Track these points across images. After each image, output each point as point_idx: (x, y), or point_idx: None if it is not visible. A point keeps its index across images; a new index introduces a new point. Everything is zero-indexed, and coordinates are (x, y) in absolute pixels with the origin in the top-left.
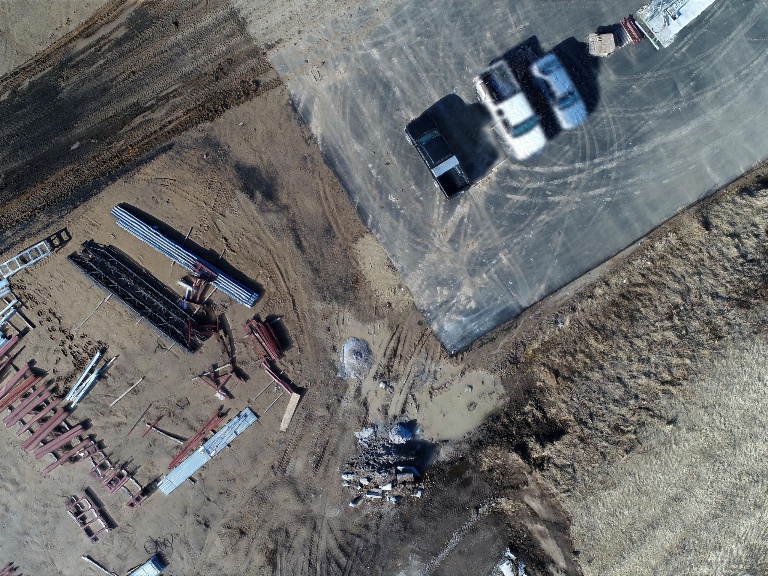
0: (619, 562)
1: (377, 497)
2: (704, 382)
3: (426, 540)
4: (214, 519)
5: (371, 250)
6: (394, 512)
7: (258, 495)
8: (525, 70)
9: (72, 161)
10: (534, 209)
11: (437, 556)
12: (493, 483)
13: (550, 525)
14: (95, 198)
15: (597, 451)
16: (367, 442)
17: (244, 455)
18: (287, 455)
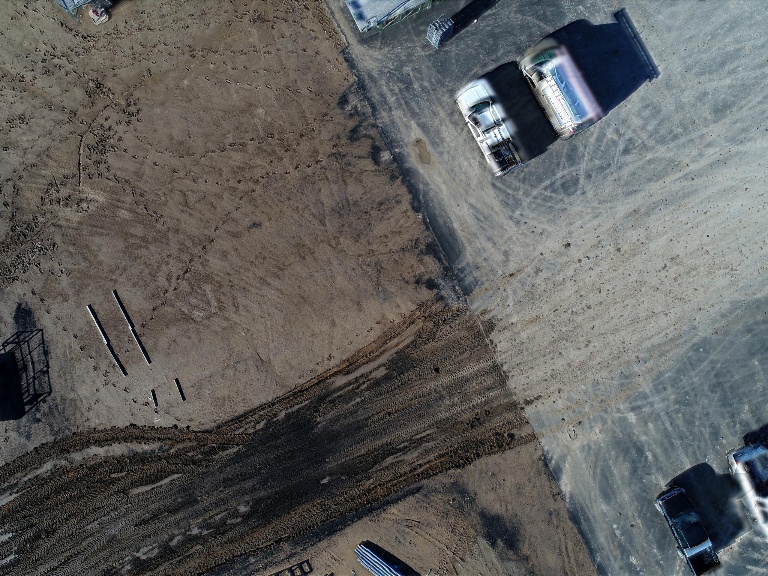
0: None
1: None
2: None
3: None
4: None
5: None
6: None
7: None
8: None
9: (320, 495)
10: None
11: None
12: None
13: None
14: (339, 533)
15: None
16: None
17: None
18: None
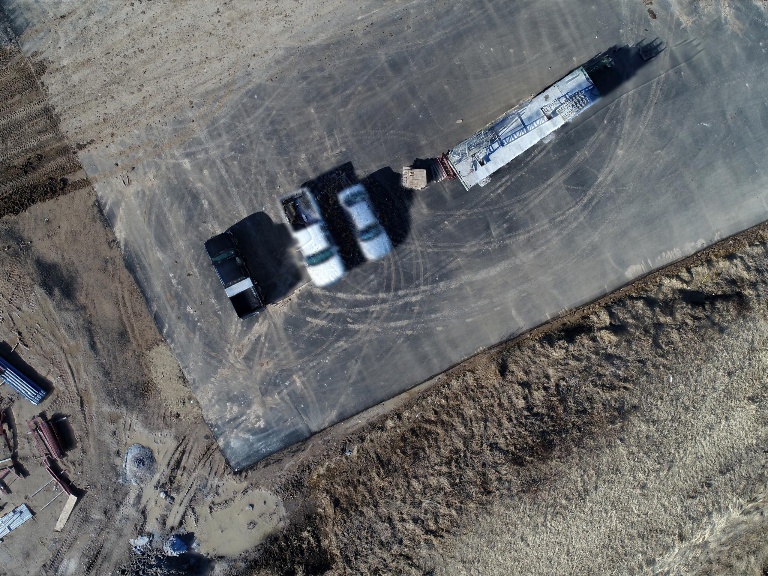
0: None
1: None
2: (466, 536)
3: None
4: None
5: (164, 359)
6: None
7: None
8: (337, 195)
9: None
10: (333, 335)
11: None
12: None
13: None
14: None
15: None
16: (141, 550)
17: (16, 551)
18: (60, 555)
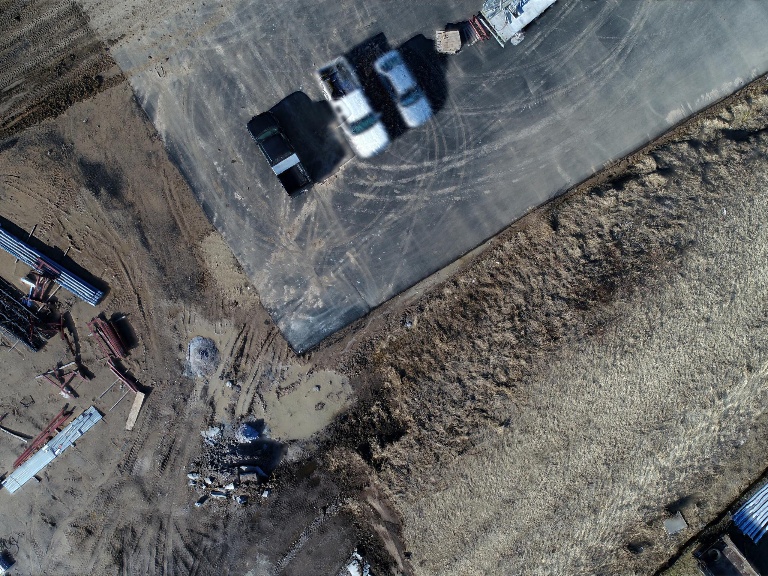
0: (450, 563)
1: (222, 496)
2: (538, 383)
3: (274, 540)
4: (60, 517)
5: (217, 248)
6: (241, 511)
7: (104, 494)
8: (373, 67)
9: None
10: (382, 208)
11: (285, 556)
12: (340, 483)
13: (389, 525)
14: None
15: (431, 452)
16: (213, 441)
17: (89, 454)
18: (133, 454)
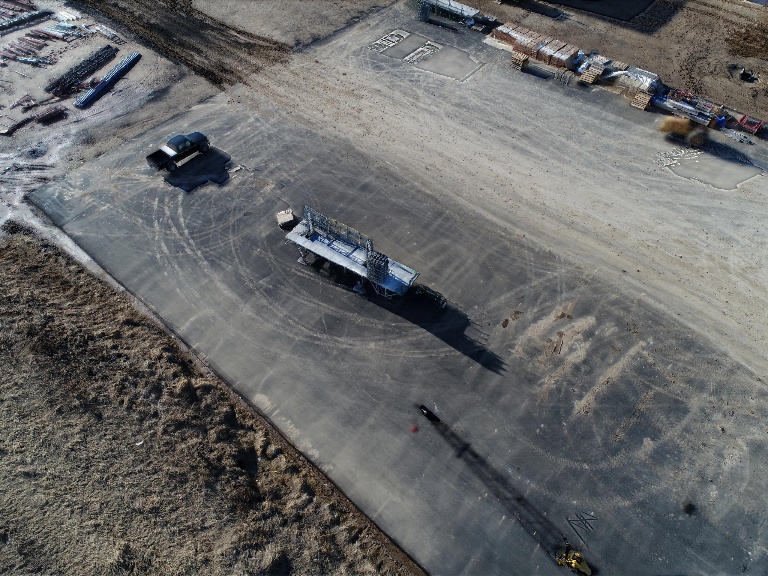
0: None
1: None
2: None
3: None
4: None
5: (112, 144)
6: None
7: None
8: (257, 187)
9: (166, 39)
10: (147, 215)
11: None
12: None
13: None
14: (144, 48)
15: None
16: None
17: None
18: None
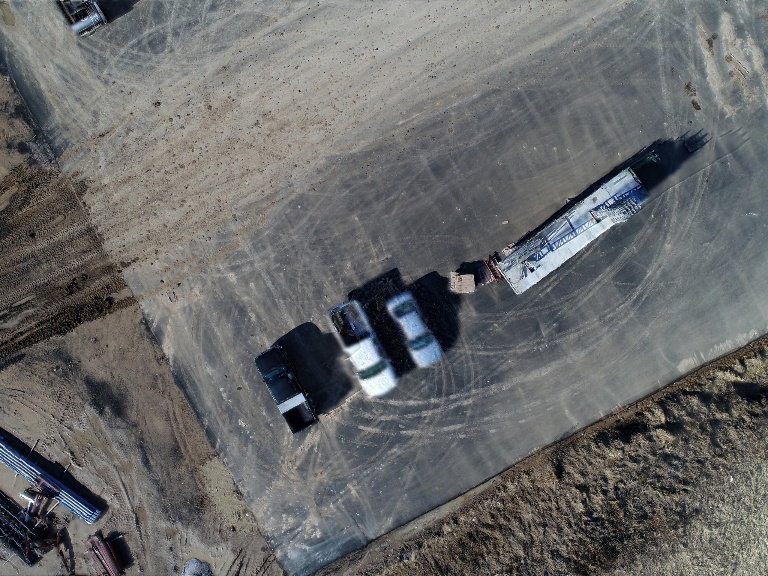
0: None
1: None
2: None
3: None
4: None
5: (218, 473)
6: None
7: None
8: (385, 302)
9: None
10: (386, 442)
11: None
12: None
13: None
14: None
15: None
16: None
17: None
18: None
